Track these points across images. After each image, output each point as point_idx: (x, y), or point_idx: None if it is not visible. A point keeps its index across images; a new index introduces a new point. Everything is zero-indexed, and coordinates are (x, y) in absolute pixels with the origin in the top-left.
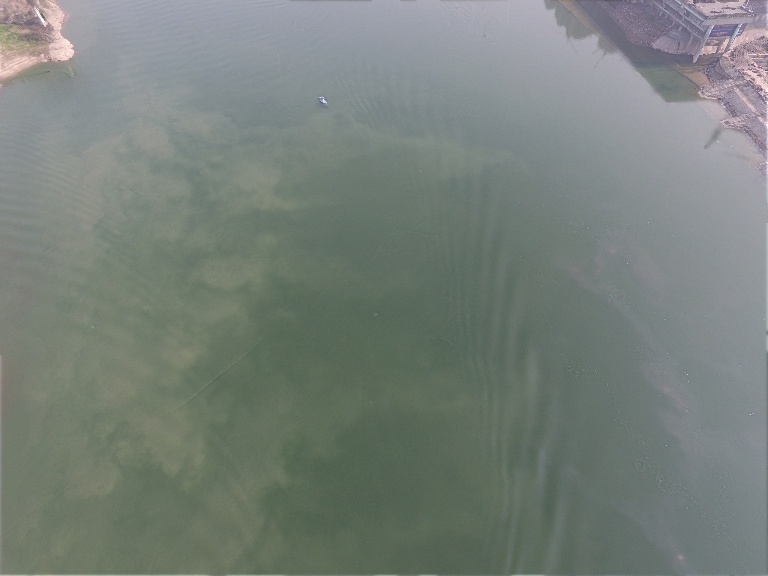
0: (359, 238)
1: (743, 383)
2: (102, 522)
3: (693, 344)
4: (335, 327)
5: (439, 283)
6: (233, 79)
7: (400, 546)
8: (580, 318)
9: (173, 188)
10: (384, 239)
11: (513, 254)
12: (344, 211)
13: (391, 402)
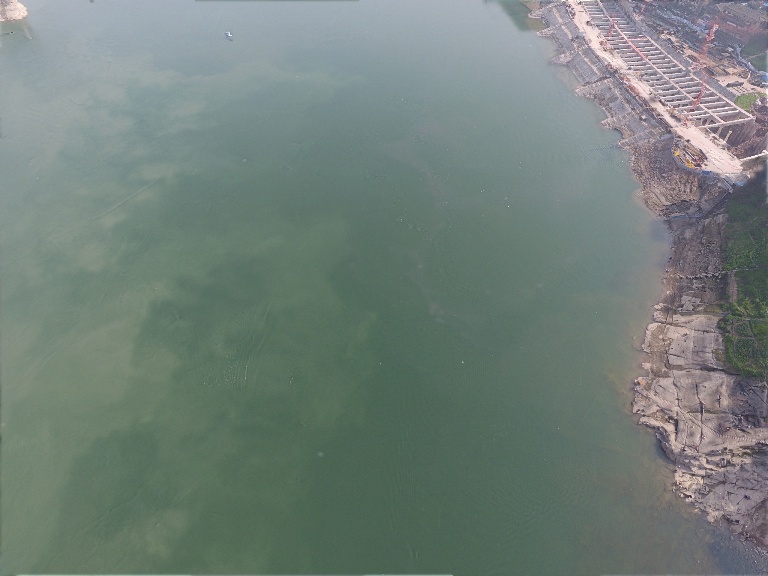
0: (241, 118)
1: (485, 177)
2: (42, 272)
3: (460, 160)
4: (214, 168)
5: (291, 137)
6: (159, 26)
7: (234, 266)
8: (388, 152)
9: (103, 97)
10: (256, 114)
11: (348, 117)
12: (233, 104)
13: (246, 205)
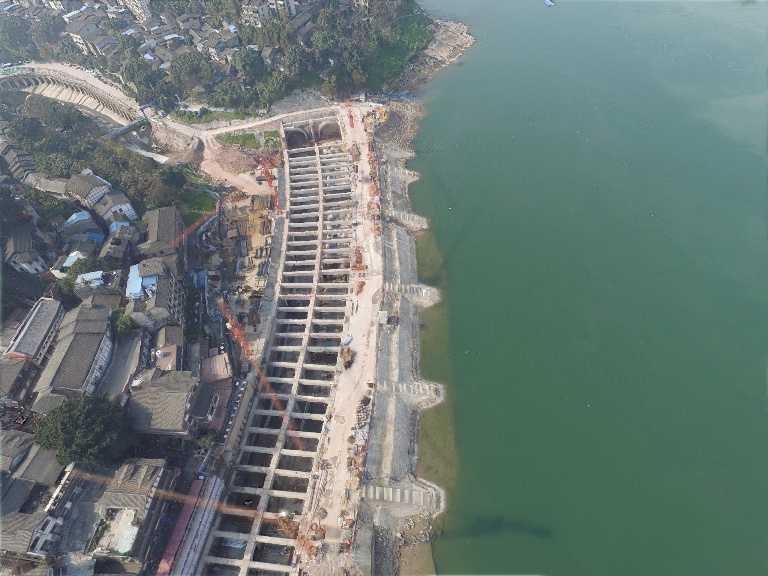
0: None
1: (546, 128)
2: None
3: (570, 144)
4: None
5: None
6: None
7: None
8: (648, 157)
9: None
10: None
11: (721, 184)
12: None
13: (756, 124)
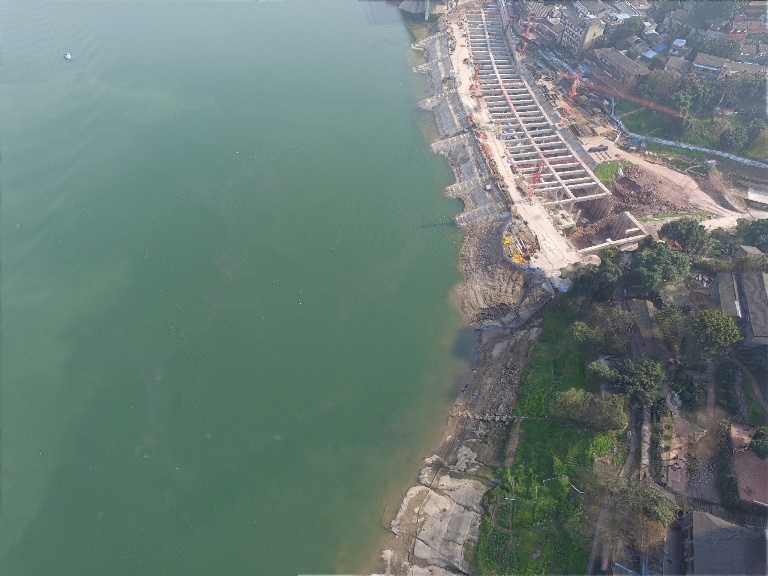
0: (37, 167)
1: (286, 260)
2: None
3: (267, 235)
4: None
5: (79, 198)
6: None
7: None
8: (189, 221)
9: None
10: (47, 165)
11: (154, 173)
12: (38, 147)
13: None
